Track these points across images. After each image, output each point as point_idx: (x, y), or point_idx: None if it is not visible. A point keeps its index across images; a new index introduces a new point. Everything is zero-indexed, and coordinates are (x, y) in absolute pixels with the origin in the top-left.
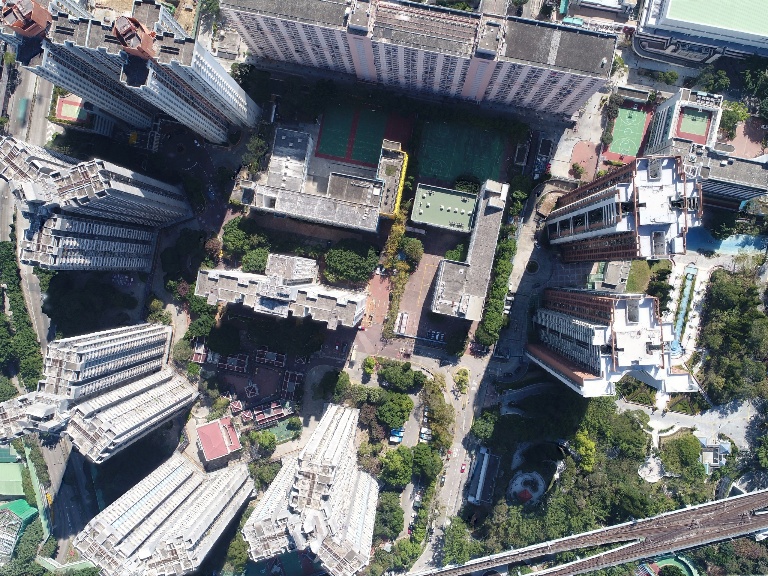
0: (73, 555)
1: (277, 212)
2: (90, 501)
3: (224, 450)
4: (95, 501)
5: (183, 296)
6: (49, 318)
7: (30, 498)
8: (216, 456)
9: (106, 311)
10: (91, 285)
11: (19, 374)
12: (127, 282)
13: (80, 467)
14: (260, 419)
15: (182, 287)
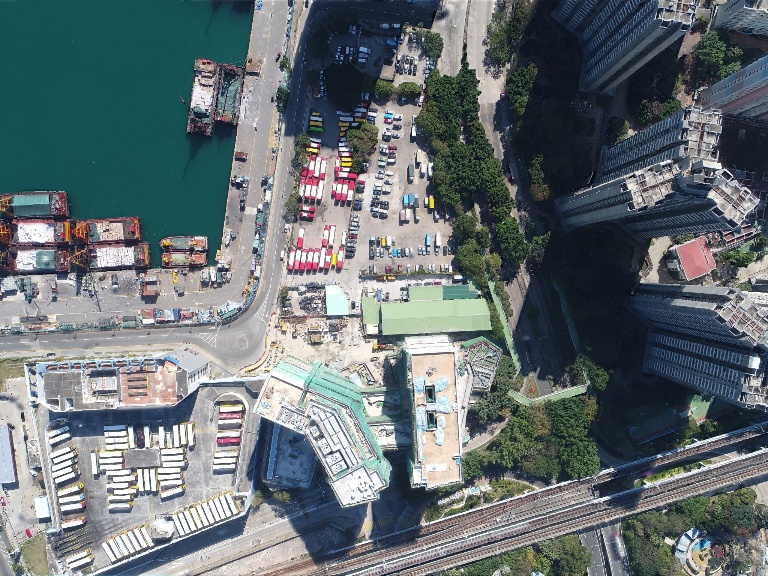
0: (533, 392)
1: (754, 24)
2: (561, 331)
3: (706, 268)
4: (566, 331)
5: (656, 115)
6: (502, 150)
7: (498, 332)
8: (697, 275)
9: (582, 132)
10: (564, 107)
11: (473, 209)
12: (586, 108)
13: (538, 302)
14: (731, 239)
15: (656, 106)
